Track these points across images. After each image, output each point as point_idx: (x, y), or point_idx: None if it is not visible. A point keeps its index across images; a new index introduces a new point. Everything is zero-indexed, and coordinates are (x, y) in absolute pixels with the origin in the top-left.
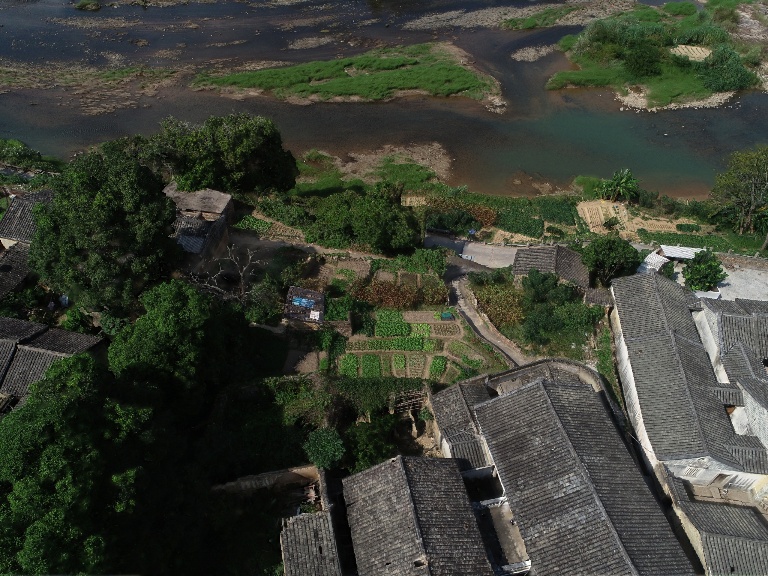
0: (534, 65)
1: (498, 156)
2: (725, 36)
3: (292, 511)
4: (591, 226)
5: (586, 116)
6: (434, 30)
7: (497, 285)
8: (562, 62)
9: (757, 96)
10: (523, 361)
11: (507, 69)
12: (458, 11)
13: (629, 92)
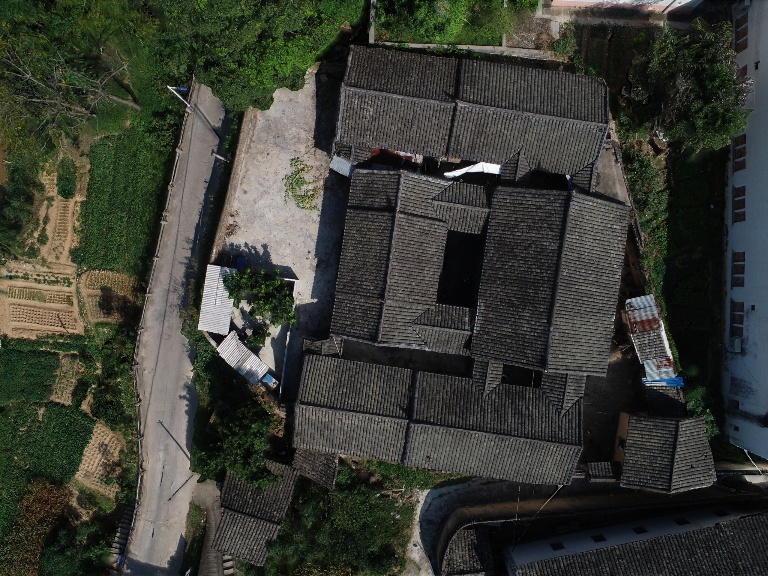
0: None
1: None
2: None
3: None
4: (61, 329)
5: None
6: None
7: (268, 573)
8: None
9: None
10: (412, 575)
11: None
12: None
13: None
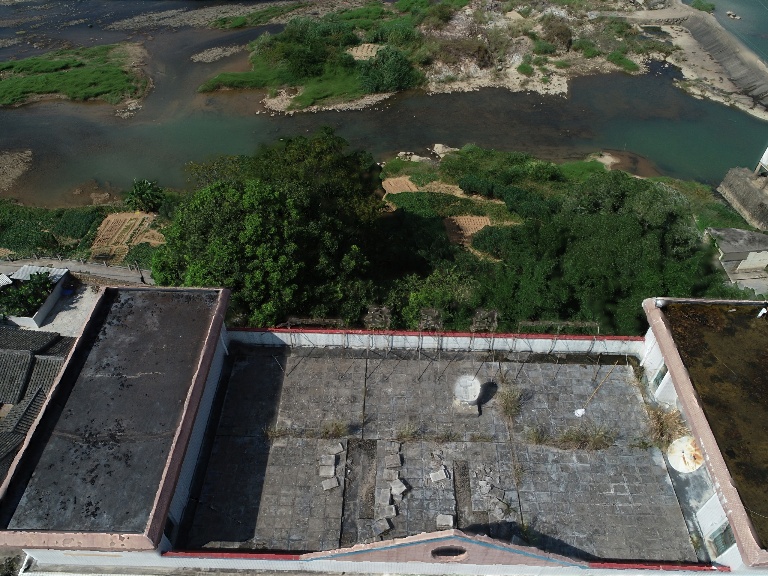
0: (207, 66)
1: (84, 164)
2: (410, 34)
3: None
4: (98, 240)
5: (217, 120)
6: (135, 30)
7: None
8: (240, 63)
9: (416, 97)
10: None
11: (175, 71)
12: (179, 10)
13: (280, 94)
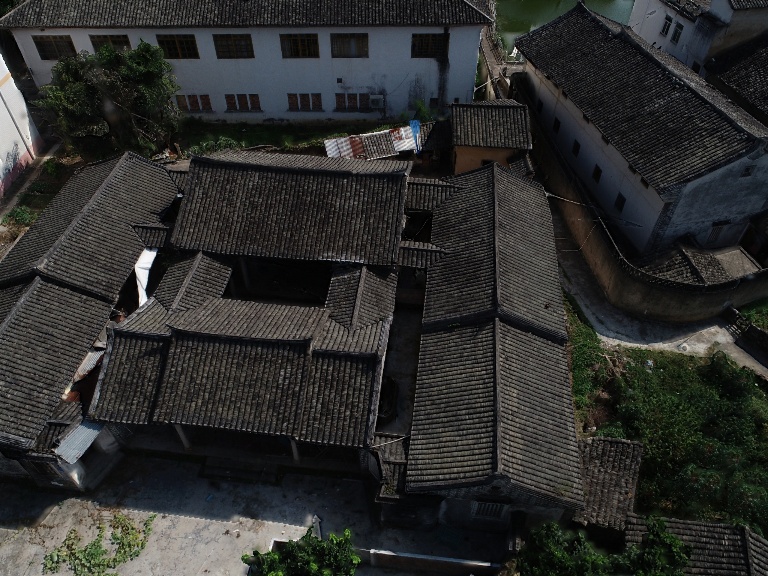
0: None
1: None
2: None
3: None
4: None
5: None
6: None
7: None
8: None
9: None
10: (731, 353)
11: None
12: None
13: None
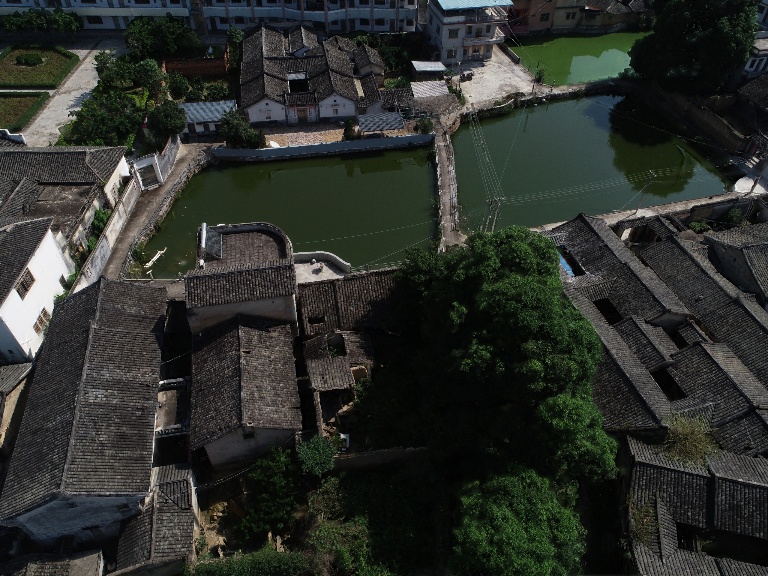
0: None
1: None
2: None
3: (354, 448)
4: None
5: None
6: None
7: None
8: None
9: None
10: None
11: None
12: None
13: None
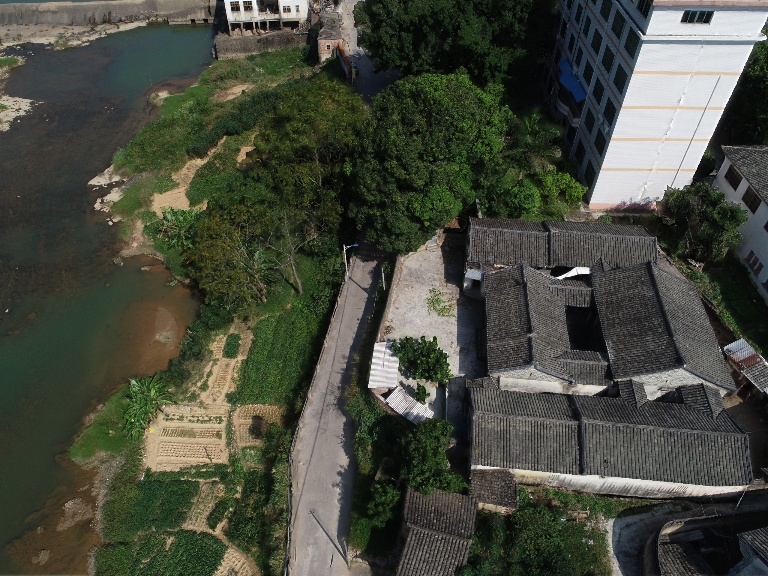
0: None
1: None
2: None
3: None
4: (206, 460)
5: None
6: None
7: None
8: None
9: None
10: None
11: None
12: None
13: None
